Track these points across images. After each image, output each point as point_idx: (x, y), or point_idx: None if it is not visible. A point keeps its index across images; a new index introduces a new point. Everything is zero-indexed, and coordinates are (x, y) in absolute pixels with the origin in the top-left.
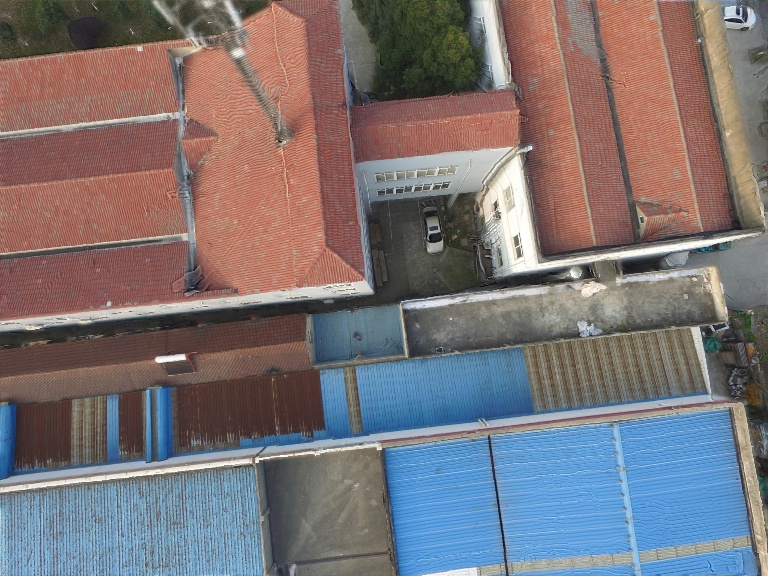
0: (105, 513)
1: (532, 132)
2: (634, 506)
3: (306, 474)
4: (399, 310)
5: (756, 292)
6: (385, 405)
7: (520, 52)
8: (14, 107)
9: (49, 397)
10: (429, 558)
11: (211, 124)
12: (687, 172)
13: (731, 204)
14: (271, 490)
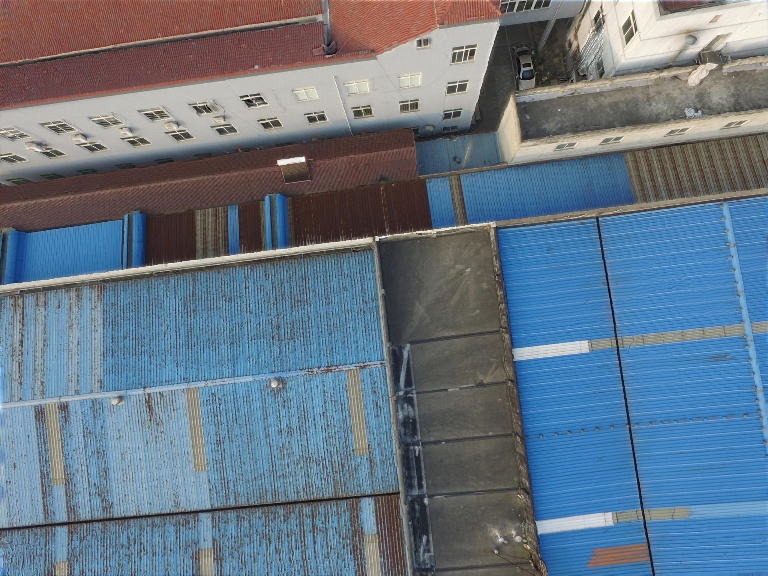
0: (234, 293)
1: None
2: (745, 280)
3: (419, 260)
4: (496, 136)
5: None
6: (490, 208)
7: None
8: None
9: (175, 208)
10: (541, 332)
11: None
12: None
13: None
14: (386, 275)
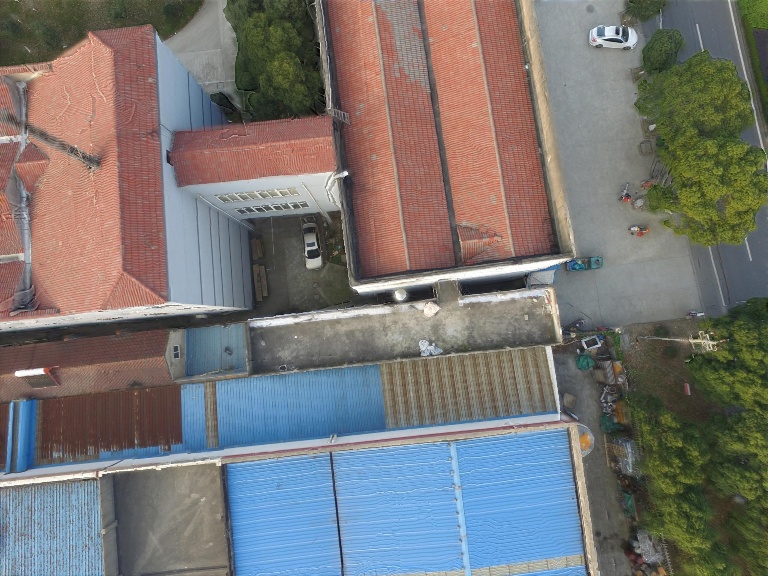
0: None
1: (358, 157)
2: (468, 524)
3: (154, 488)
4: None
5: (632, 310)
6: (242, 420)
7: (349, 78)
8: None
9: None
10: (267, 572)
11: (45, 148)
12: (501, 198)
13: (551, 228)
14: (120, 503)
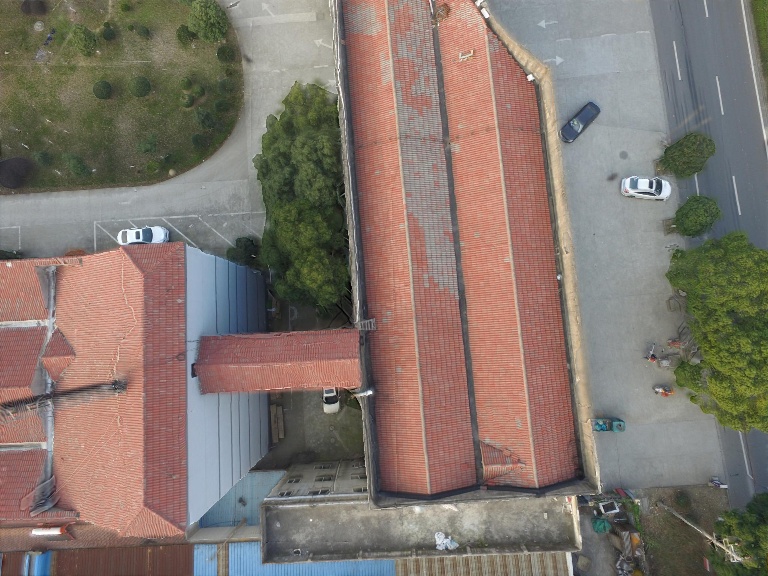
0: None
1: (382, 364)
2: None
3: None
4: None
5: (652, 472)
6: None
7: (377, 282)
8: None
9: None
10: None
11: (72, 340)
12: (527, 424)
13: (576, 450)
14: None
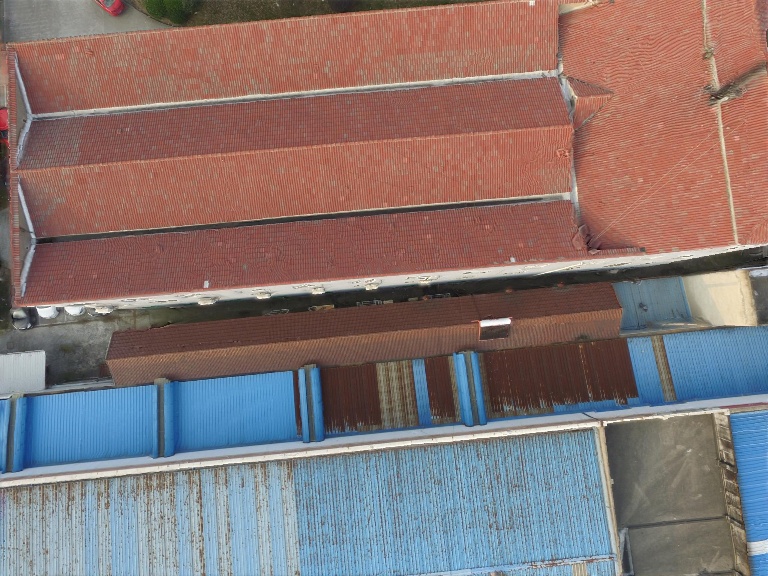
0: (444, 475)
1: None
2: None
3: (638, 439)
4: (682, 282)
5: None
6: (697, 374)
7: None
8: (392, 59)
9: (353, 360)
10: None
11: (600, 82)
12: None
13: None
14: None
